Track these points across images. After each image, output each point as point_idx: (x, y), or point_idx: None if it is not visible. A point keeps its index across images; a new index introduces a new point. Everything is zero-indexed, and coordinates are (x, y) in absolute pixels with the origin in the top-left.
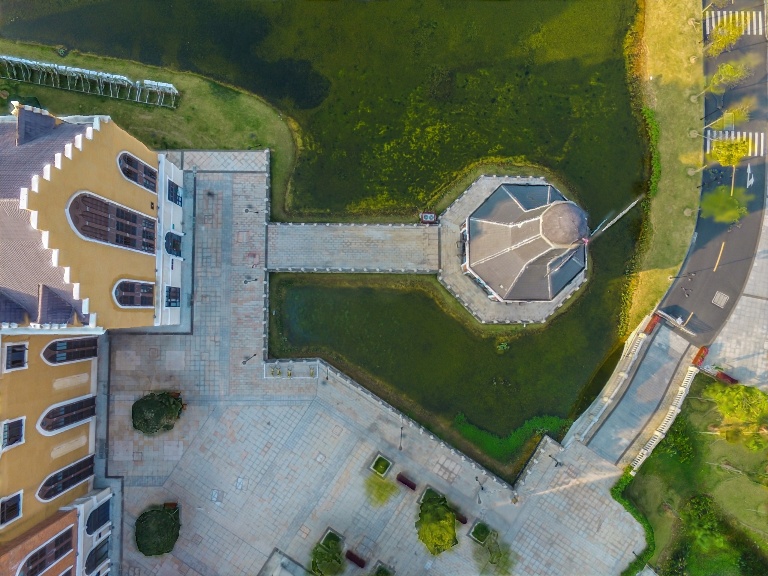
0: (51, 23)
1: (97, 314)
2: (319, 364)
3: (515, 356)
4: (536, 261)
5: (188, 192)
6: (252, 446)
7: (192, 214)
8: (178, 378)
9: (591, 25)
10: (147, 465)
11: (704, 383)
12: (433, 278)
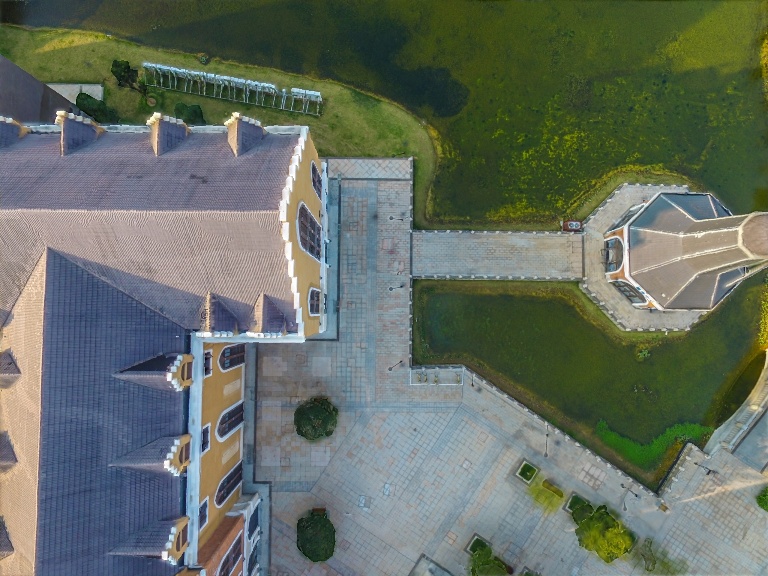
0: (192, 31)
1: (304, 323)
2: (464, 371)
3: (655, 363)
4: (714, 271)
5: (333, 199)
6: (399, 452)
7: (337, 221)
8: (325, 384)
9: (728, 34)
10: (294, 471)
11: None
12: (574, 286)
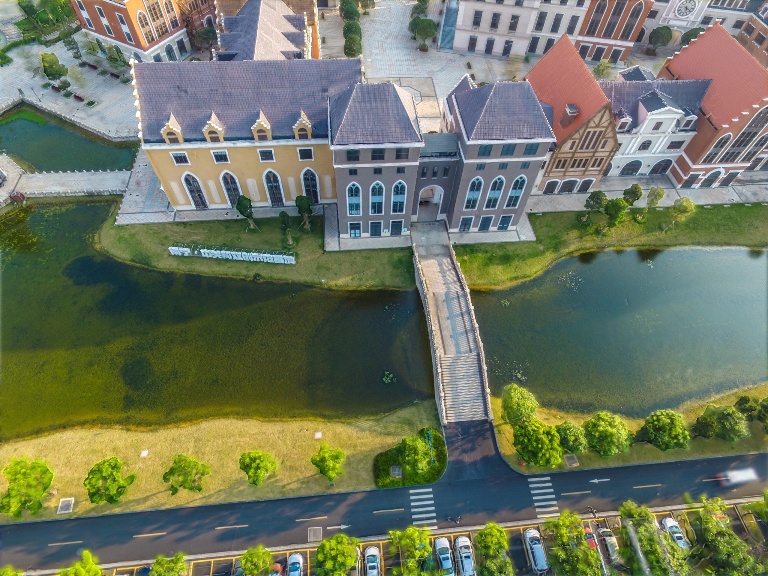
0: (267, 296)
1: None
2: None
3: None
4: None
5: None
6: None
7: None
8: None
9: None
10: None
11: None
12: None
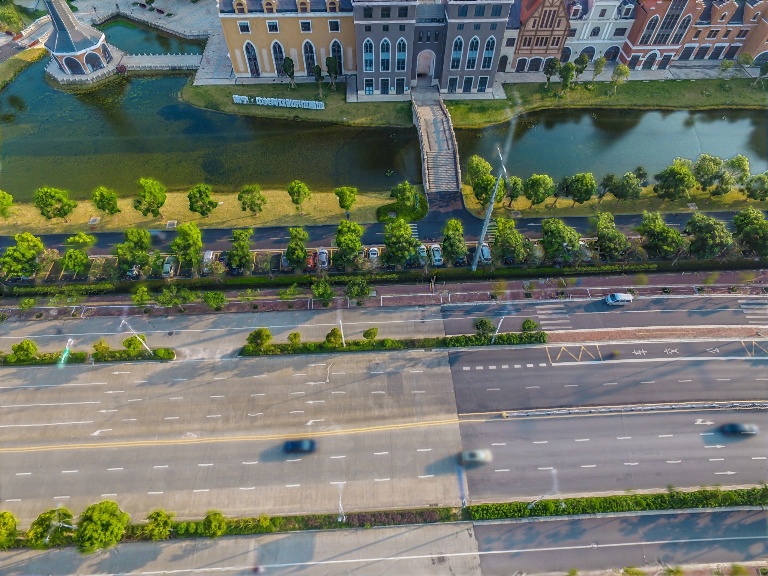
0: None
1: None
2: None
3: None
4: None
5: None
6: None
7: None
8: None
9: None
10: None
11: None
12: None
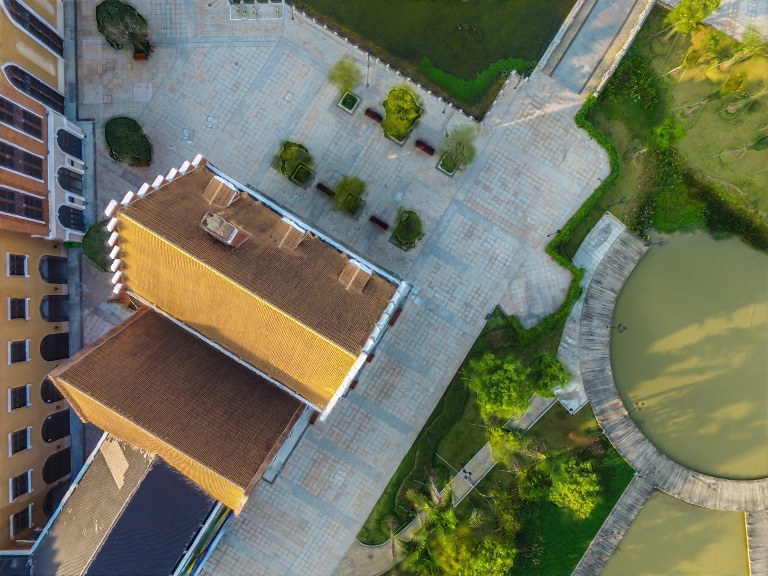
0: None
1: None
2: (284, 5)
3: (479, 3)
4: None
5: None
6: (221, 86)
7: None
8: None
9: None
10: (117, 107)
11: None
12: None
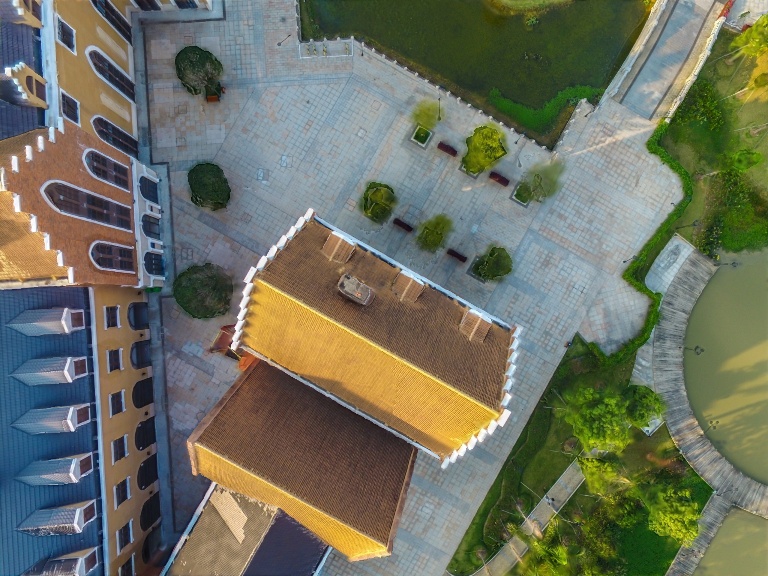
0: None
1: None
2: (353, 42)
3: (544, 31)
4: None
5: None
6: (293, 125)
7: None
8: None
9: None
10: (191, 150)
11: (730, 40)
12: None
